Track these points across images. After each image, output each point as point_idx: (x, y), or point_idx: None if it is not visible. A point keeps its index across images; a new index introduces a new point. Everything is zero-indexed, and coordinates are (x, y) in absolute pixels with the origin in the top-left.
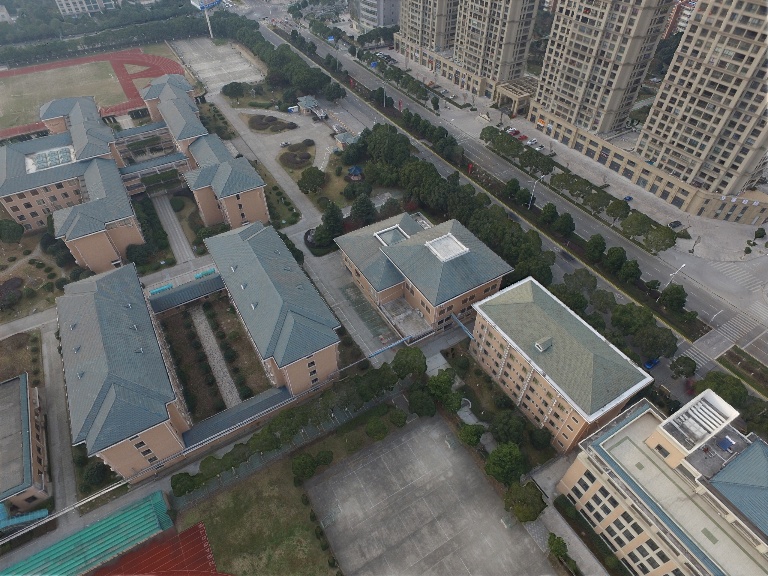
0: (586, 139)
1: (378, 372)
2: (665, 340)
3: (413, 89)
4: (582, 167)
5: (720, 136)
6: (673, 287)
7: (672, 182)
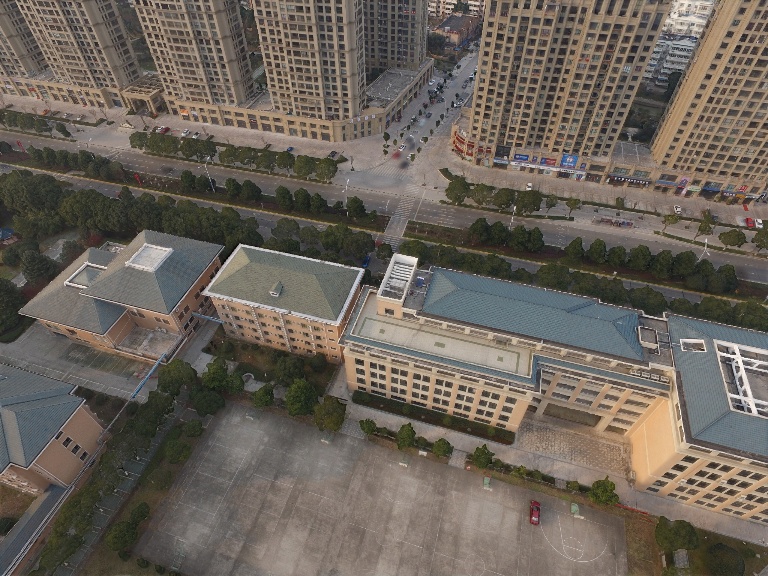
0: (231, 113)
1: (148, 404)
2: (363, 240)
3: (26, 124)
4: (241, 138)
5: (323, 75)
6: (350, 200)
7: (313, 123)
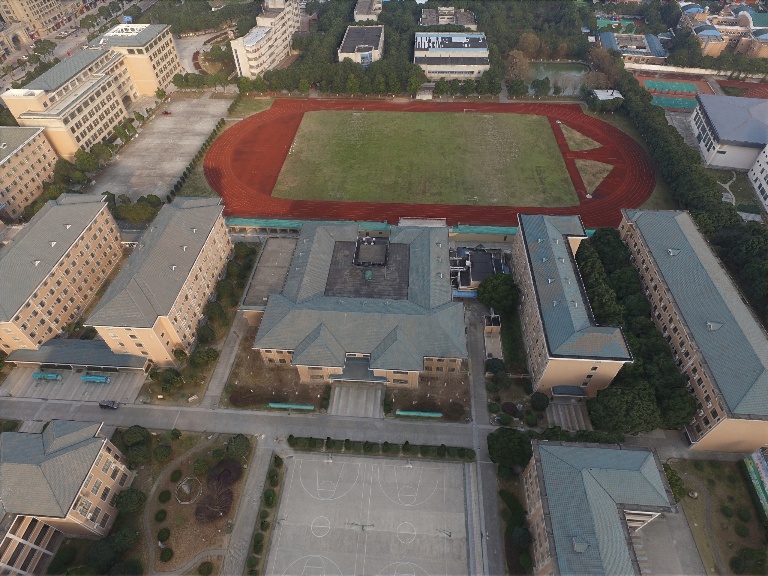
0: None
1: None
2: None
3: None
4: None
5: None
6: None
7: None
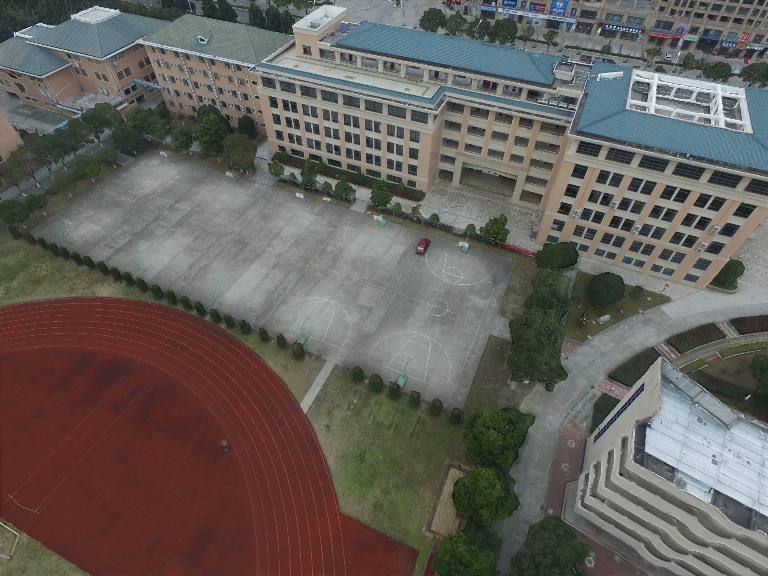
0: None
1: (68, 128)
2: None
3: None
4: None
5: None
6: None
7: None
